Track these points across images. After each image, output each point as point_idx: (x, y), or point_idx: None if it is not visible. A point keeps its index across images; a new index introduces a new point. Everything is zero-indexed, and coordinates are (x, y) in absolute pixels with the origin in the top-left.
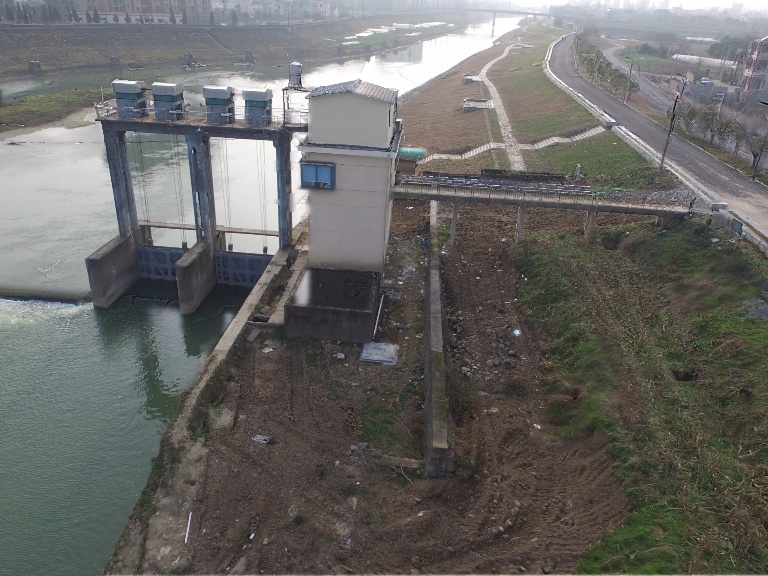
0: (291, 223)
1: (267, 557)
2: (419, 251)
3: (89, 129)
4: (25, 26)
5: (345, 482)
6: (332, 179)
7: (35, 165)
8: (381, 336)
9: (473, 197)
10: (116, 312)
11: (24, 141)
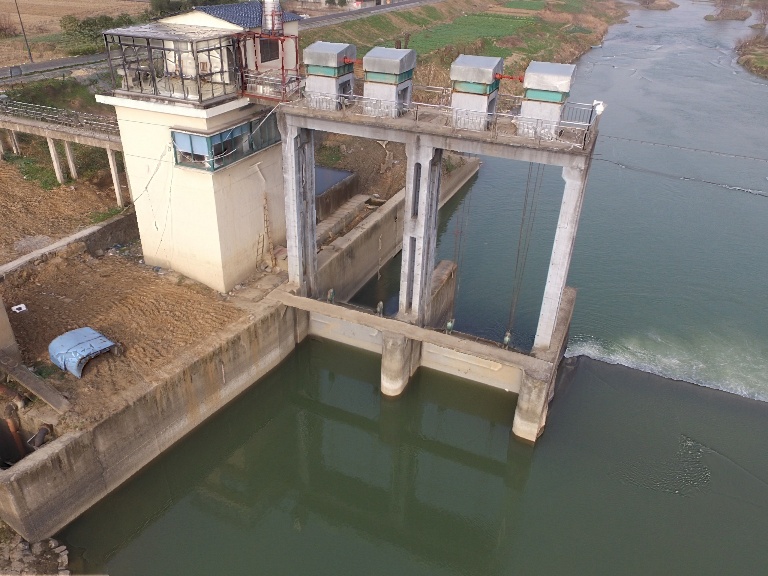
0: (290, 257)
1: (402, 146)
2: None
3: None
4: None
5: (364, 139)
6: None
7: None
8: None
9: None
10: None
11: None
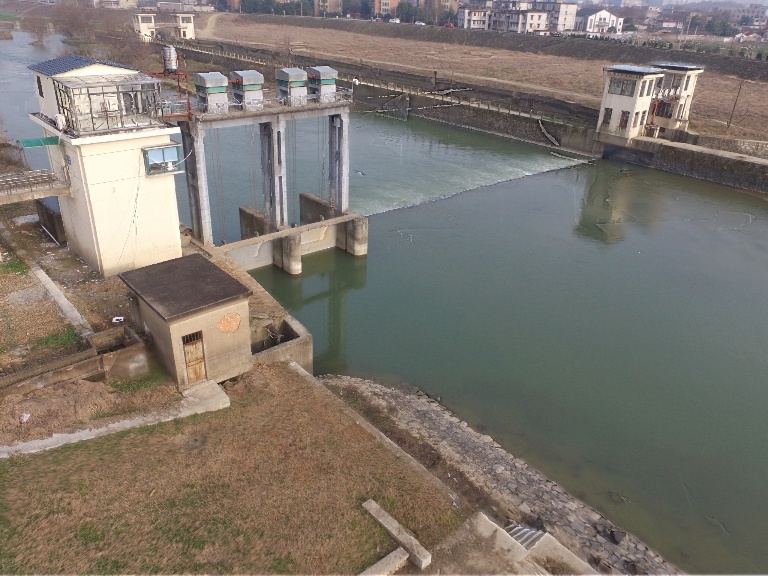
0: (203, 225)
1: None
2: (52, 276)
3: None
4: None
5: None
6: None
7: None
8: (37, 226)
9: None
10: None
11: None
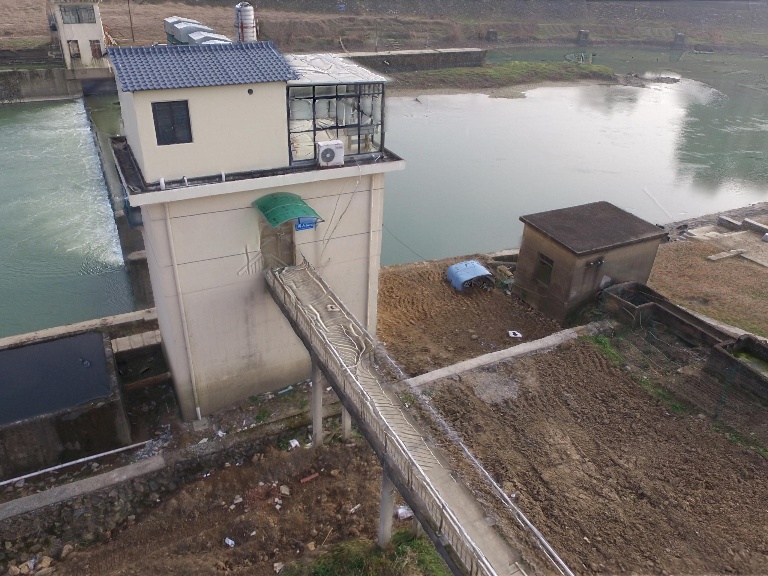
0: None
1: None
2: None
3: (508, 102)
4: None
5: None
6: (129, 209)
7: (394, 123)
8: None
9: (327, 368)
10: (128, 279)
11: (432, 100)
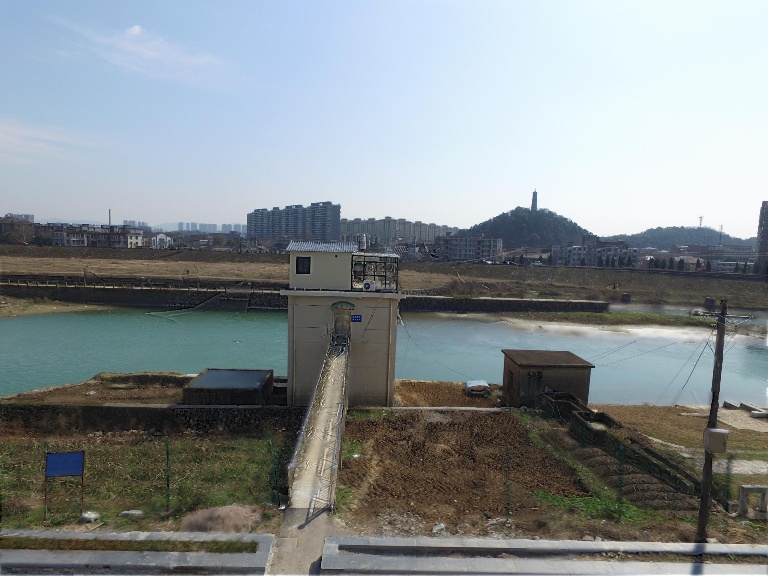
0: None
1: None
2: None
3: (613, 333)
4: (741, 275)
5: None
6: None
7: (515, 336)
8: None
9: None
10: None
11: (552, 328)
